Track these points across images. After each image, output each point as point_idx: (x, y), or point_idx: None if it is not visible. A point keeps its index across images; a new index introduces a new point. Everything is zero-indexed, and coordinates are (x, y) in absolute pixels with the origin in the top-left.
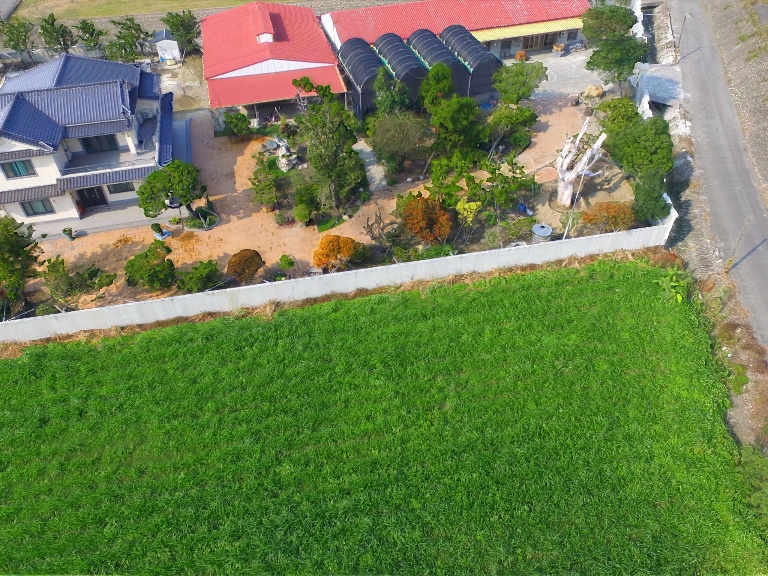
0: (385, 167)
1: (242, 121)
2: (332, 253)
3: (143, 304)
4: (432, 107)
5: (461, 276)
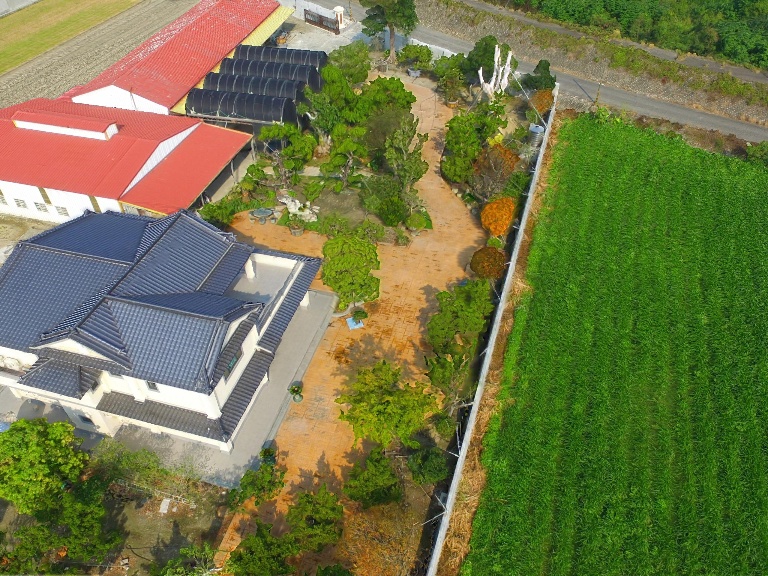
0: (366, 169)
1: (219, 209)
2: None
3: None
4: None
5: None
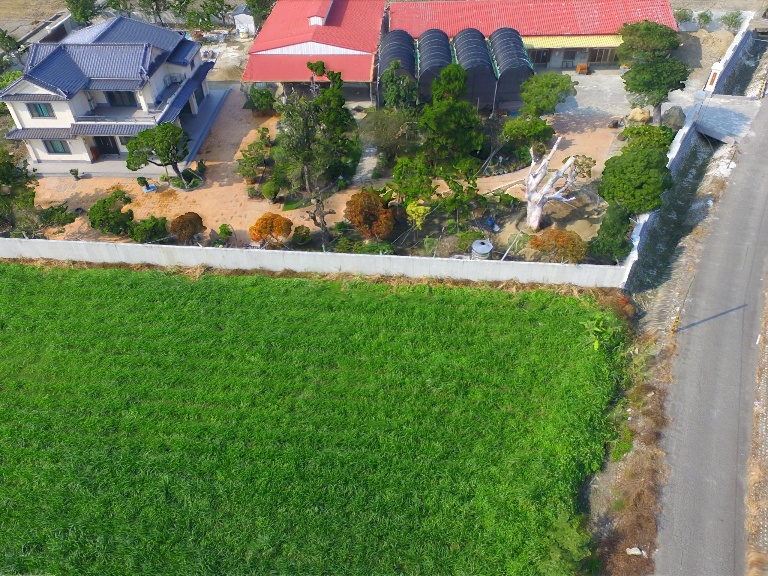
0: (378, 160)
1: (265, 97)
2: (264, 230)
3: (91, 244)
4: (426, 106)
5: (389, 277)
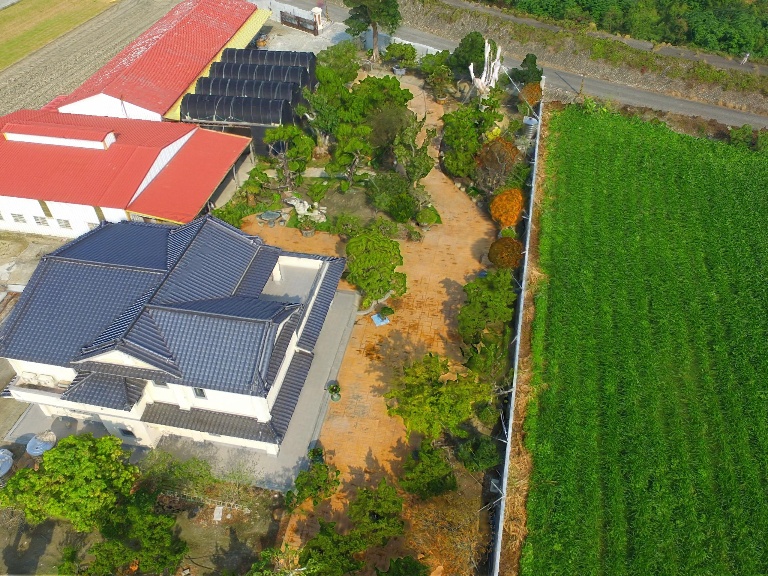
0: (367, 168)
1: (228, 214)
2: None
3: None
4: (378, 95)
5: None
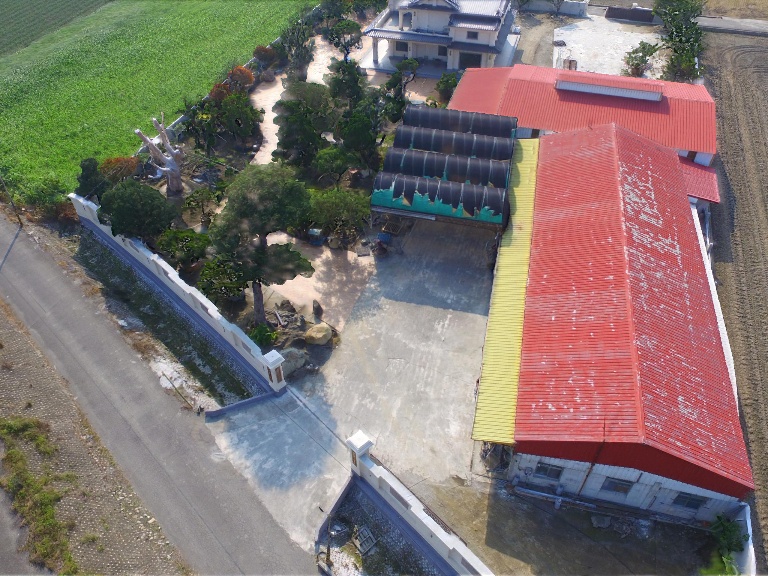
0: None
1: None
2: None
3: None
4: None
5: None
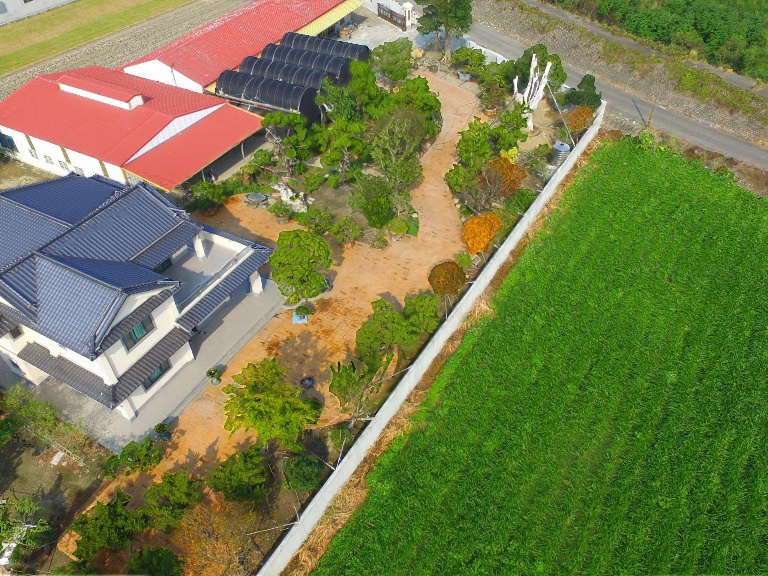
0: (375, 168)
1: (212, 188)
2: None
3: (419, 363)
4: None
5: None
